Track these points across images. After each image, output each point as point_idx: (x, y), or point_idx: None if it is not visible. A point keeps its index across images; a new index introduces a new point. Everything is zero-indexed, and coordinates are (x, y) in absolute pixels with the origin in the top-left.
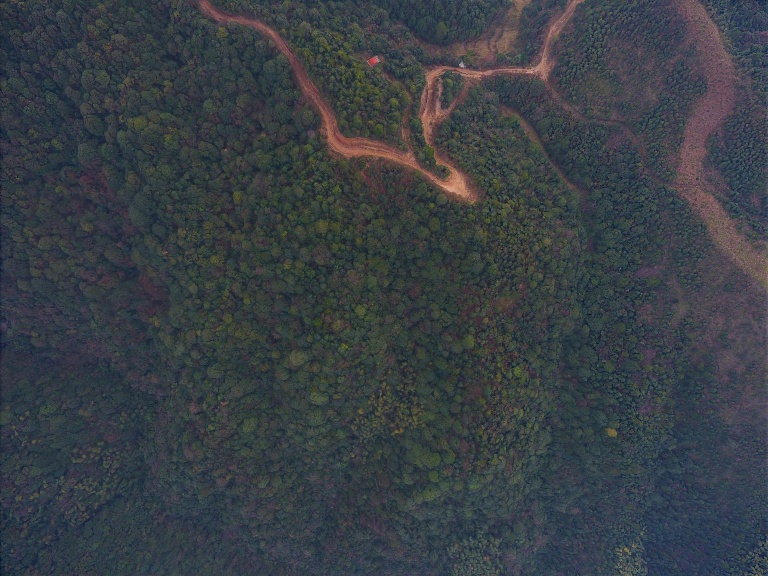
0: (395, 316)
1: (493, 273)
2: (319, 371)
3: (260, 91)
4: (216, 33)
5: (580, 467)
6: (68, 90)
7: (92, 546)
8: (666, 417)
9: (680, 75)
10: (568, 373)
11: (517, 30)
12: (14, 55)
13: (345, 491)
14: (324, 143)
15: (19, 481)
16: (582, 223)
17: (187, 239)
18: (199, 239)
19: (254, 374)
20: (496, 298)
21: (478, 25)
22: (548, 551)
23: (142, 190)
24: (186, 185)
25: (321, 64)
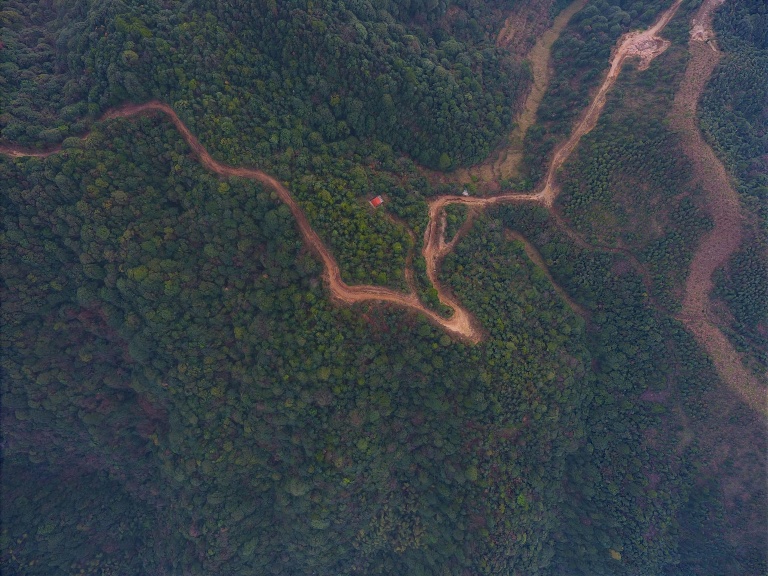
0: (397, 443)
1: (497, 412)
2: (320, 501)
3: (262, 234)
4: (217, 188)
5: None
6: (67, 242)
7: None
8: None
9: (686, 212)
10: (571, 488)
11: (521, 153)
12: (12, 209)
13: None
14: (326, 291)
15: None
16: (586, 344)
17: (187, 374)
18: (199, 373)
19: (254, 494)
20: (500, 430)
21: (482, 153)
22: None
23: (142, 331)
24: (186, 325)
25: (324, 218)
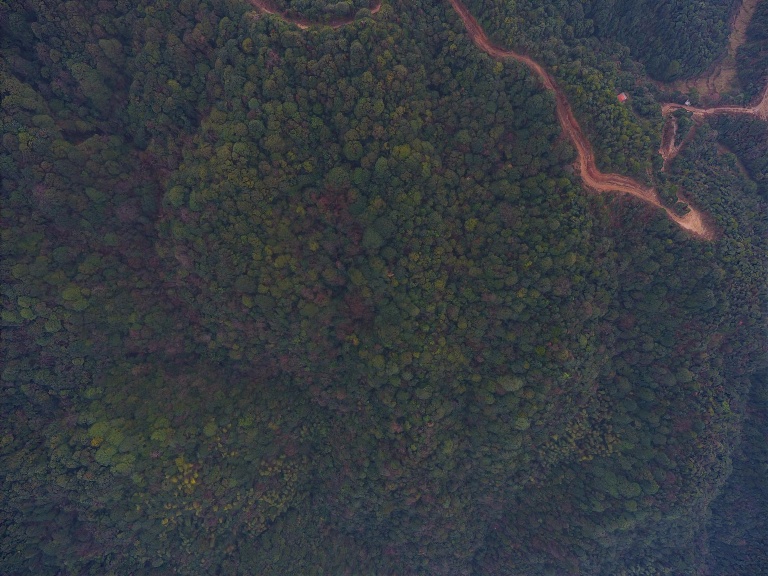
0: (605, 346)
1: (724, 310)
2: (532, 398)
3: (513, 123)
4: (493, 67)
5: (759, 501)
6: (339, 116)
7: (273, 558)
8: None
9: None
10: (753, 407)
11: (734, 69)
12: (292, 80)
13: (513, 513)
14: (580, 178)
15: (219, 492)
16: None
17: (418, 263)
18: (429, 264)
19: (451, 396)
20: (714, 333)
21: (705, 64)
22: None
23: (388, 215)
24: (429, 211)
25: (592, 102)
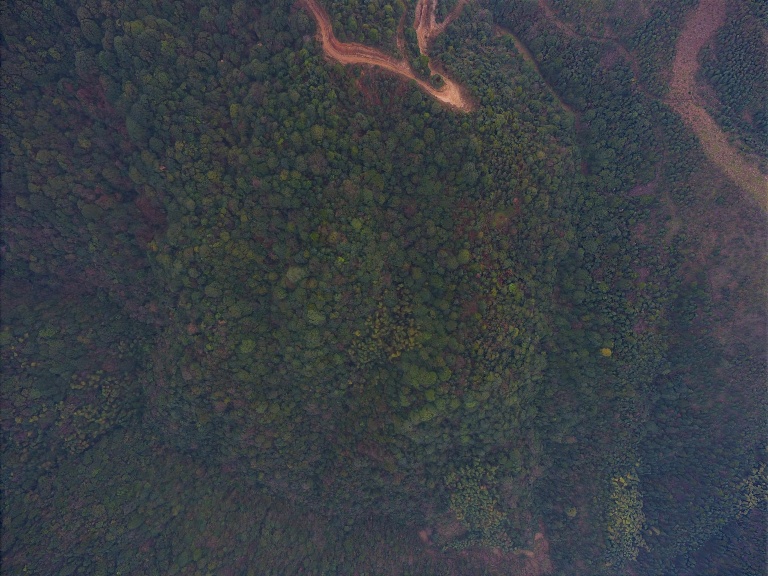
0: (391, 234)
1: (488, 183)
2: (316, 287)
3: None
4: None
5: (575, 392)
6: None
7: (91, 472)
8: (660, 338)
9: None
10: (563, 298)
11: None
12: None
13: (343, 422)
14: (319, 48)
15: (19, 402)
16: (576, 145)
17: (184, 152)
18: (196, 153)
19: (252, 297)
20: (491, 212)
21: None
22: (545, 485)
23: (139, 99)
24: (183, 95)
25: None
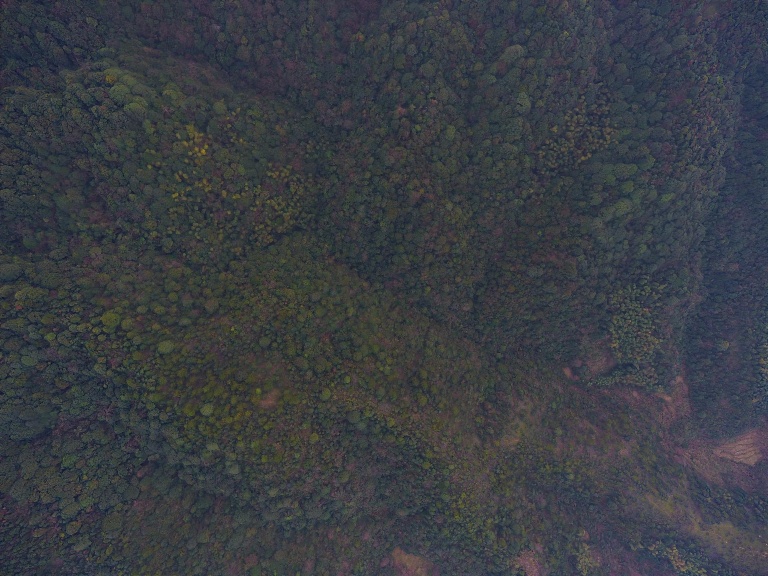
0: (604, 23)
1: None
2: (533, 67)
3: None
4: None
5: (752, 208)
6: None
7: (280, 261)
8: None
9: None
10: (746, 115)
11: None
12: None
13: (513, 238)
14: None
15: (228, 174)
16: None
17: None
18: None
19: (454, 89)
20: None
21: None
22: (693, 324)
23: None
24: None
25: None
